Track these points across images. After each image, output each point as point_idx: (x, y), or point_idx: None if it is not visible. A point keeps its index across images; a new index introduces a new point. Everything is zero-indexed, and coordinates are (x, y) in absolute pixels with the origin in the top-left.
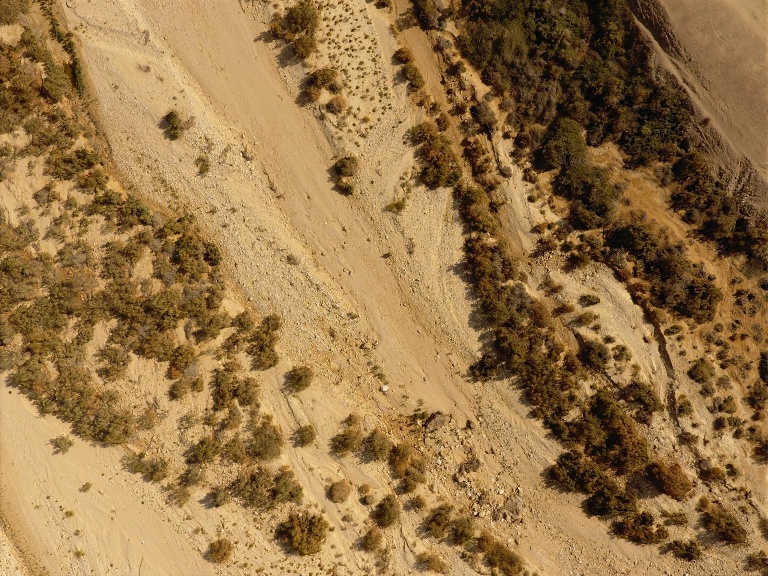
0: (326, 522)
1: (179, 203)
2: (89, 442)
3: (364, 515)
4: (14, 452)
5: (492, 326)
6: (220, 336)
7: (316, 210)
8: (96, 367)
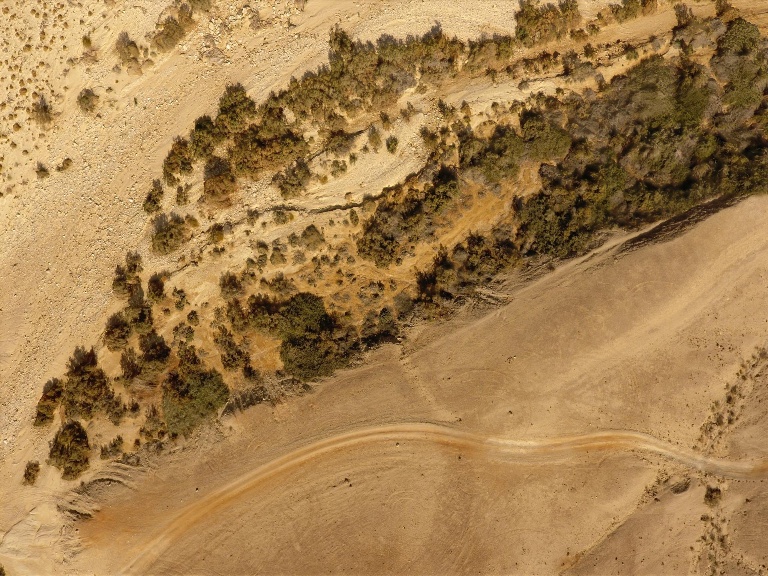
0: None
1: None
2: None
3: None
4: None
5: None
6: None
7: None
8: None
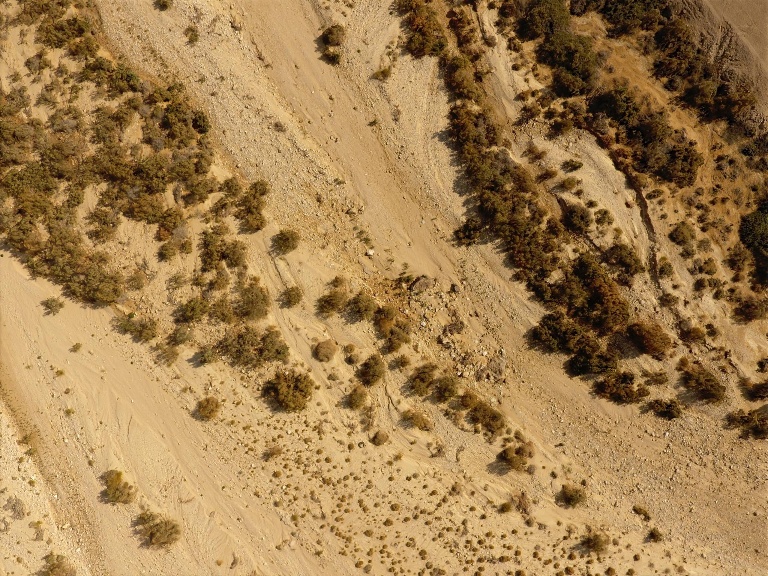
0: (312, 380)
1: (168, 72)
2: (79, 304)
3: (349, 374)
4: (6, 314)
5: (476, 190)
6: (208, 200)
7: (303, 79)
8: (86, 229)
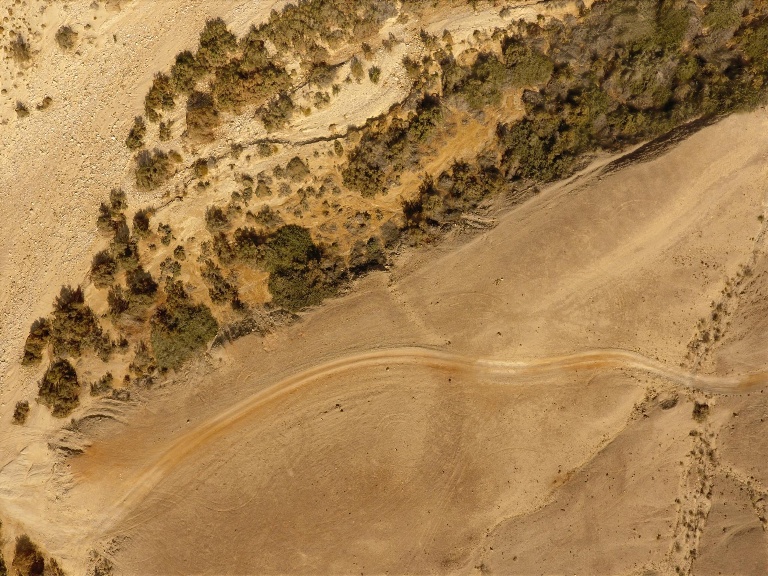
0: None
1: None
2: None
3: None
4: None
5: None
6: None
7: None
8: None
